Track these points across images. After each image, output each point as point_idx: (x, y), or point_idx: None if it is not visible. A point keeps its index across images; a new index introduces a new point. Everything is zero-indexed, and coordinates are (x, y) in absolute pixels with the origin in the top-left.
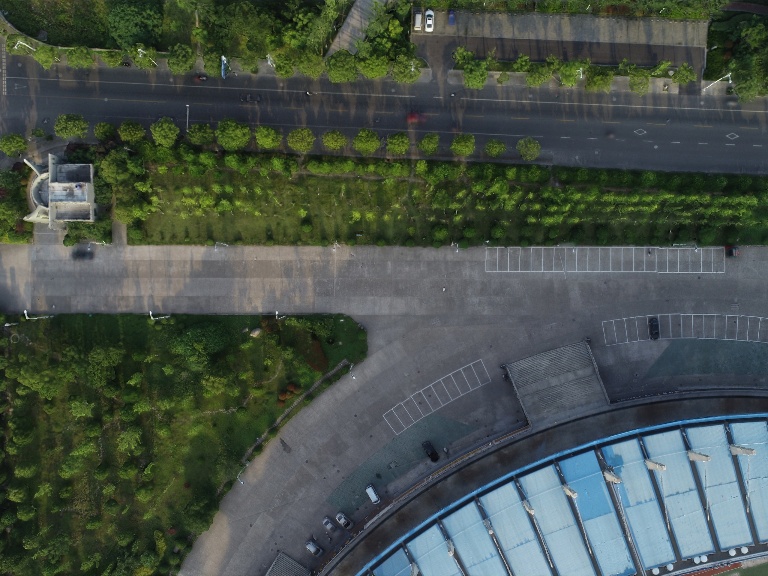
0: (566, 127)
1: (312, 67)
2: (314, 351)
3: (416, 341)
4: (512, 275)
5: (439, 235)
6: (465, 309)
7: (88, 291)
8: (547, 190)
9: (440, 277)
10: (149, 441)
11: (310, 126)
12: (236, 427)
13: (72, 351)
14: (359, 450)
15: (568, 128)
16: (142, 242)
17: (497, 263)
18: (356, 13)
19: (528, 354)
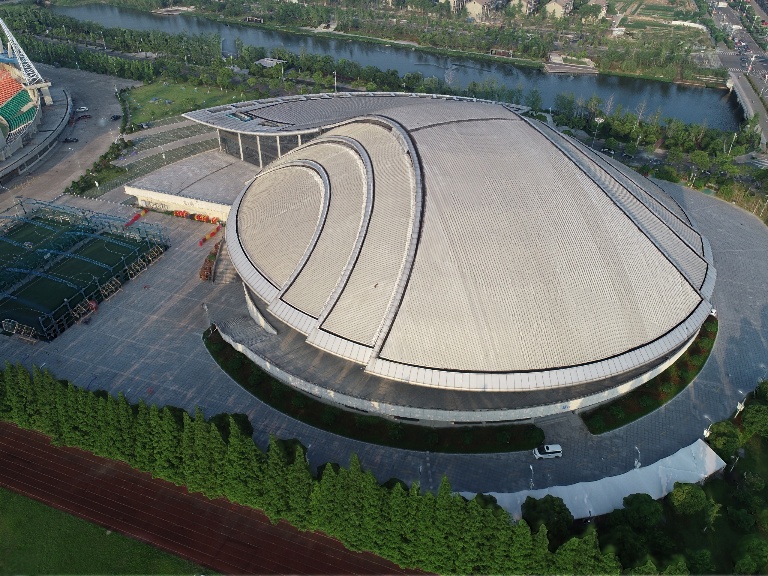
0: None
1: None
2: None
3: None
4: None
5: None
6: None
7: None
8: None
9: None
10: None
11: None
12: None
13: None
14: None
15: None
16: None
17: None
18: None
19: None
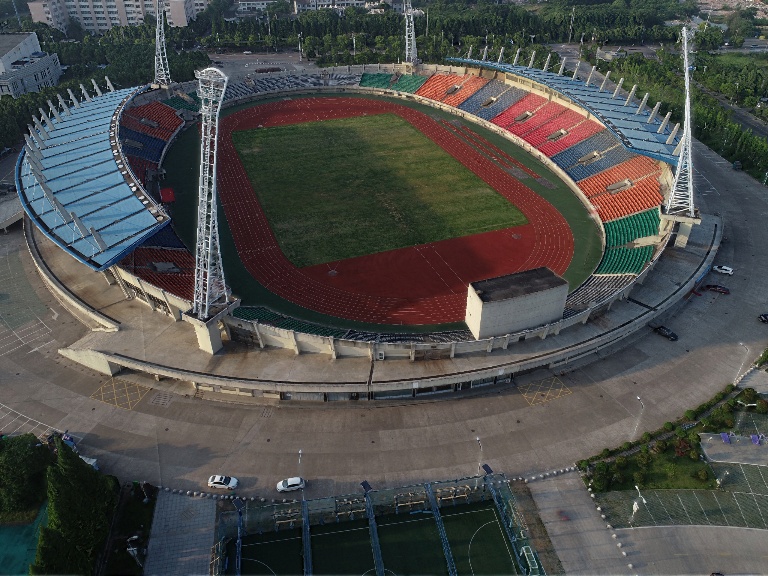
0: None
1: None
2: None
3: None
4: None
5: None
6: None
7: None
8: None
9: None
10: None
11: None
12: None
13: None
14: None
15: None
16: (602, 72)
17: None
18: None
19: None
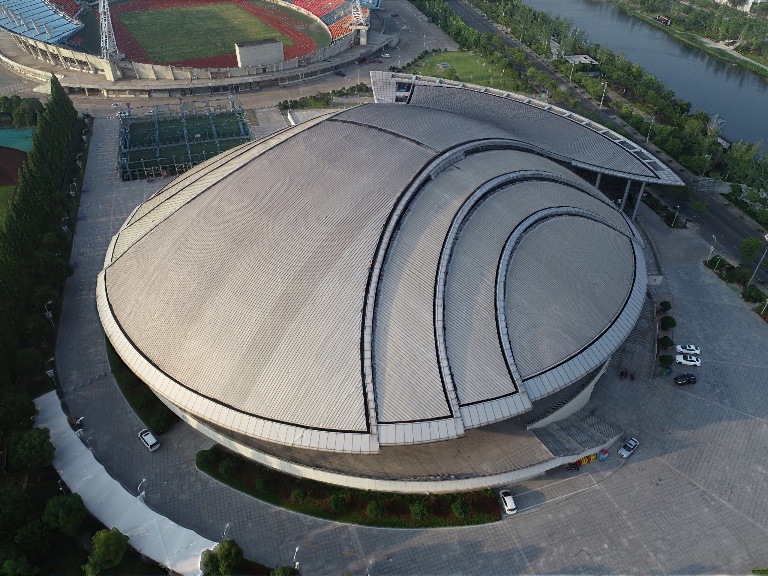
0: None
1: None
2: None
3: None
4: None
5: None
6: None
7: None
8: None
9: None
10: None
11: None
12: None
13: None
14: None
15: None
16: None
17: None
18: None
19: None
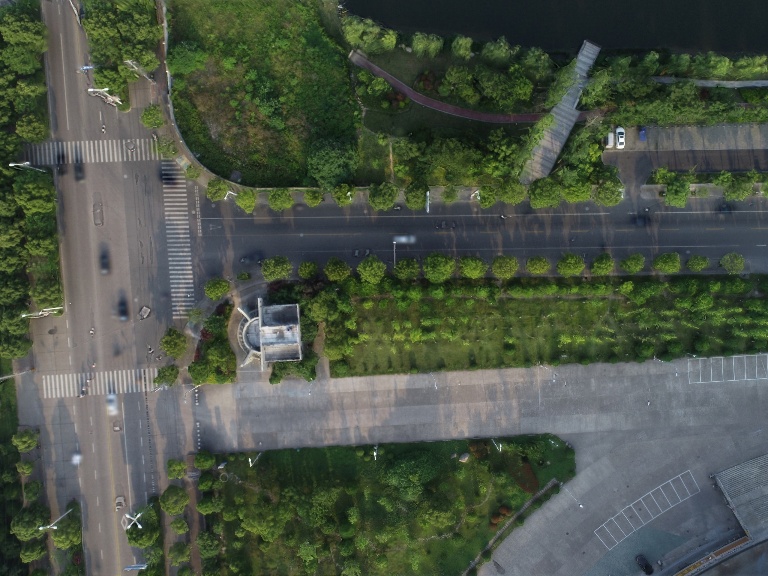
0: (761, 235)
1: (515, 196)
2: (525, 473)
3: (623, 456)
4: (716, 385)
5: (647, 353)
6: (671, 421)
7: (294, 426)
8: (755, 304)
9: (644, 391)
10: (364, 572)
11: (506, 249)
12: (449, 552)
13: (291, 492)
14: (572, 567)
15: (763, 236)
16: (346, 374)
17: (700, 374)
18: (546, 134)
19: (736, 462)
